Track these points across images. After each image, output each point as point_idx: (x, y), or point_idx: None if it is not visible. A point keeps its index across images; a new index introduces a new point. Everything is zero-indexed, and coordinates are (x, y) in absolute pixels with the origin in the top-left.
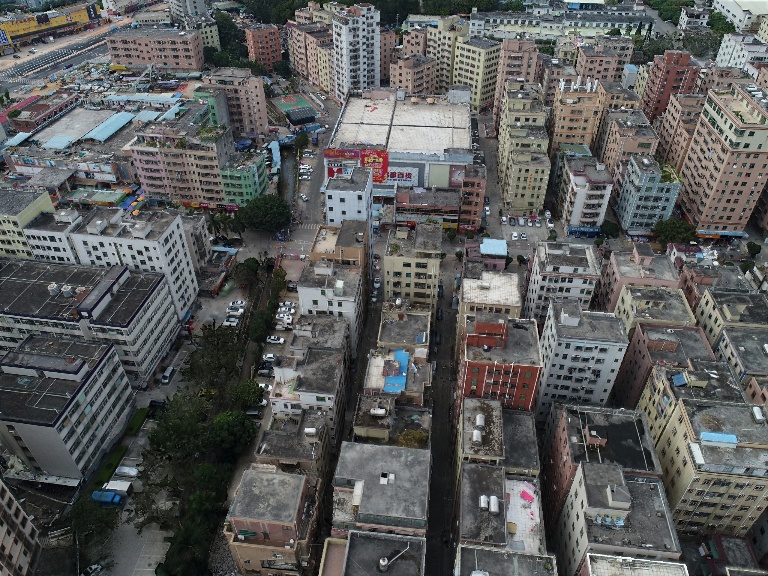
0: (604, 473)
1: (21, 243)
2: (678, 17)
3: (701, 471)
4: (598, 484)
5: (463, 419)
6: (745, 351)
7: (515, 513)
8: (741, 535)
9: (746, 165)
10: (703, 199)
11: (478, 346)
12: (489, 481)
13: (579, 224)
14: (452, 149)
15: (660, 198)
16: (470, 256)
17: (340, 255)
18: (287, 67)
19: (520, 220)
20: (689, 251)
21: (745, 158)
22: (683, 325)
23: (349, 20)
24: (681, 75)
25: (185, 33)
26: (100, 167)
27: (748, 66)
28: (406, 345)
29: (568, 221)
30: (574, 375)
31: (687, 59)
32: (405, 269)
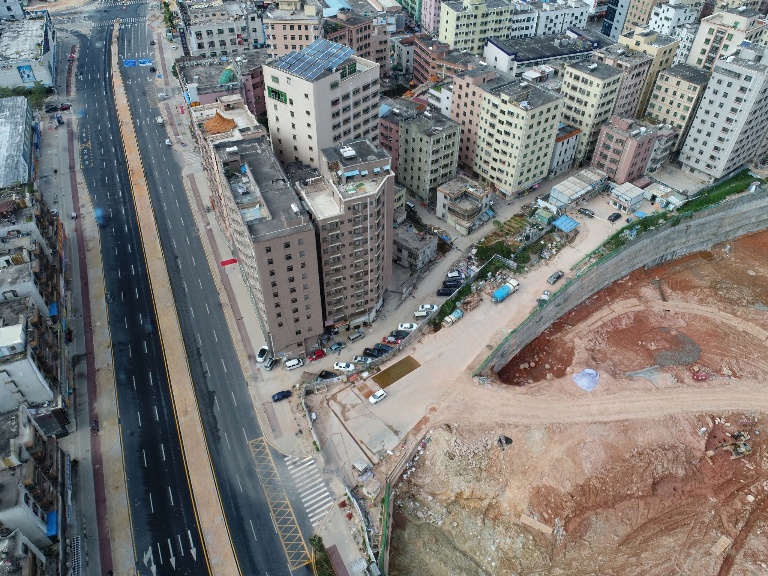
0: None
1: (507, 28)
2: None
3: None
4: None
5: None
6: None
7: None
8: None
9: None
10: None
11: None
12: None
13: None
14: None
15: None
16: None
17: None
18: None
19: None
20: None
21: None
22: None
23: None
24: None
25: None
26: (387, 20)
27: None
28: None
29: None
30: None
31: None
32: (691, 2)
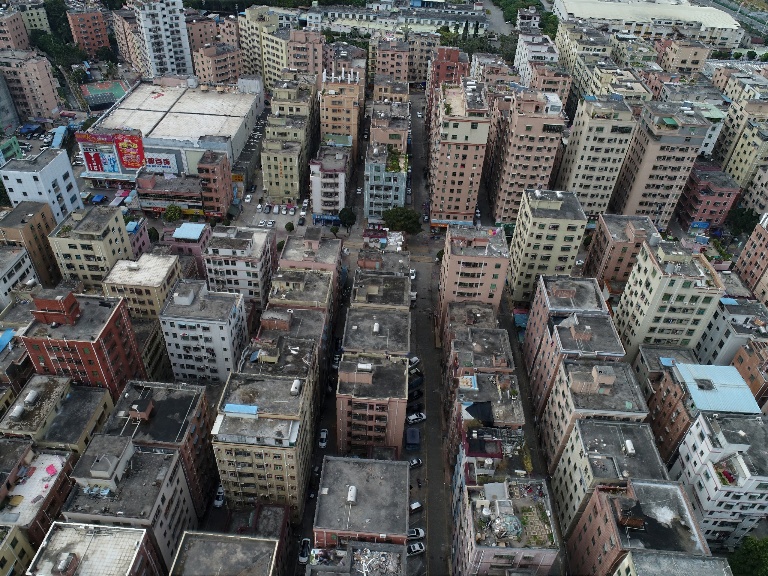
0: (109, 444)
1: None
2: (516, 18)
3: (219, 441)
4: (95, 455)
5: (19, 395)
6: (356, 330)
7: (30, 486)
8: (295, 504)
9: (459, 156)
10: (433, 189)
11: (48, 323)
12: (8, 455)
13: (322, 212)
14: (209, 136)
15: (390, 187)
16: (165, 240)
17: (3, 236)
18: (110, 53)
19: (274, 208)
20: (374, 237)
21: (456, 149)
22: (315, 306)
23: (145, 5)
24: (451, 70)
25: (2, 14)
26: None
27: (528, 65)
28: (24, 325)
29: (311, 209)
30: (193, 354)
31: (457, 55)
32: (73, 251)
